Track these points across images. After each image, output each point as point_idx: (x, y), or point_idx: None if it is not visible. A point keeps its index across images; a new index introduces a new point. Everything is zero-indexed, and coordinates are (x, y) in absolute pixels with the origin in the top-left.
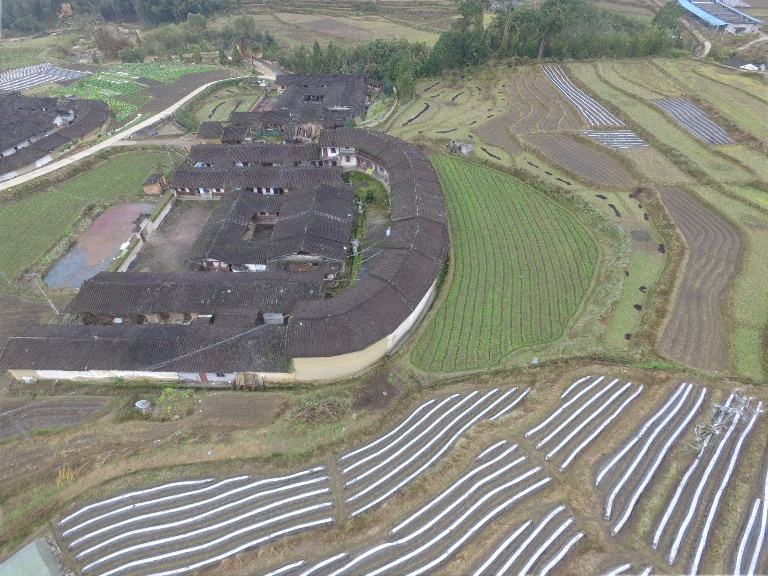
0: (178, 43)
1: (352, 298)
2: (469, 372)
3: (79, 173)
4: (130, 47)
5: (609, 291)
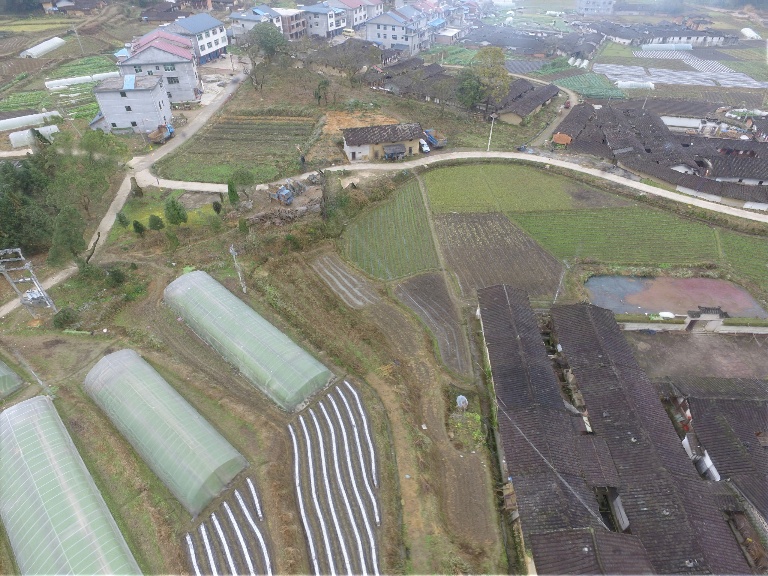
0: None
1: None
2: None
3: (762, 236)
4: None
5: None
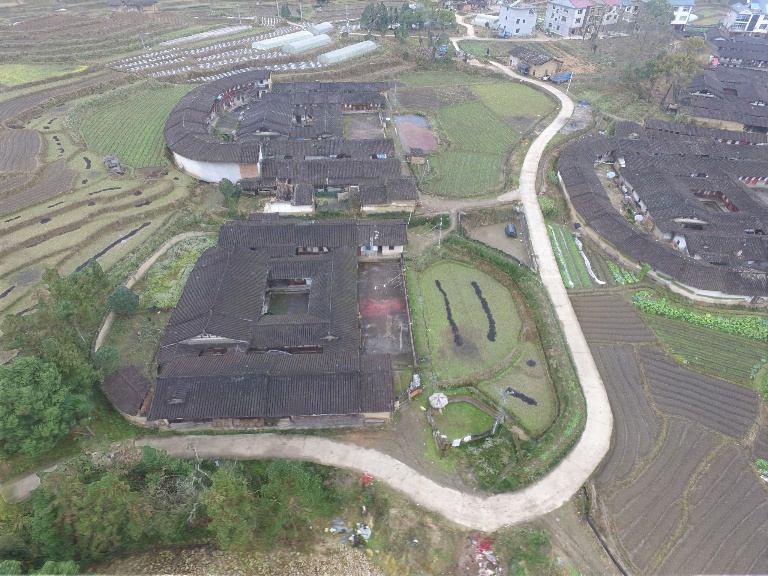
0: None
1: (245, 76)
2: (205, 83)
3: None
4: None
5: (120, 92)
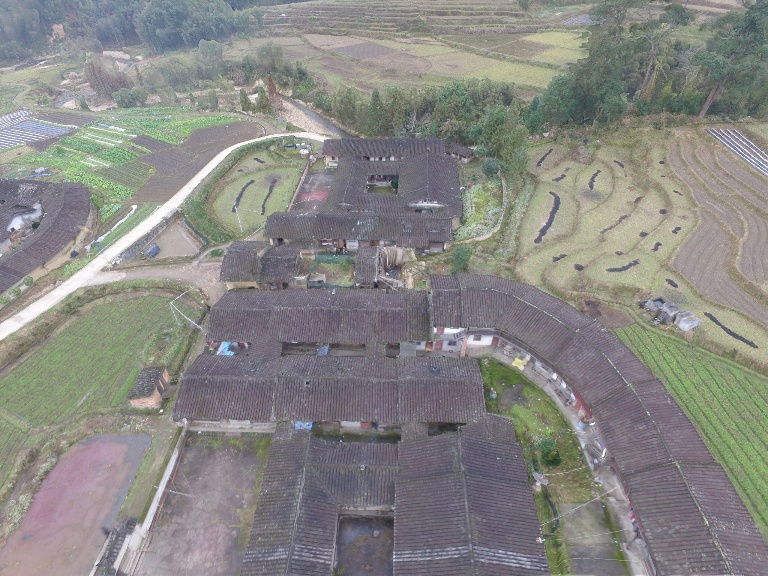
0: (188, 78)
1: None
2: None
3: (28, 350)
4: (129, 85)
5: None
